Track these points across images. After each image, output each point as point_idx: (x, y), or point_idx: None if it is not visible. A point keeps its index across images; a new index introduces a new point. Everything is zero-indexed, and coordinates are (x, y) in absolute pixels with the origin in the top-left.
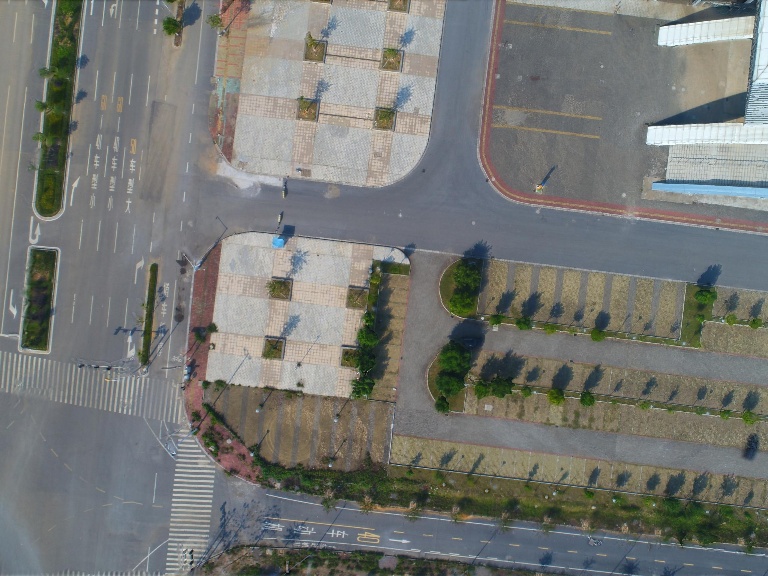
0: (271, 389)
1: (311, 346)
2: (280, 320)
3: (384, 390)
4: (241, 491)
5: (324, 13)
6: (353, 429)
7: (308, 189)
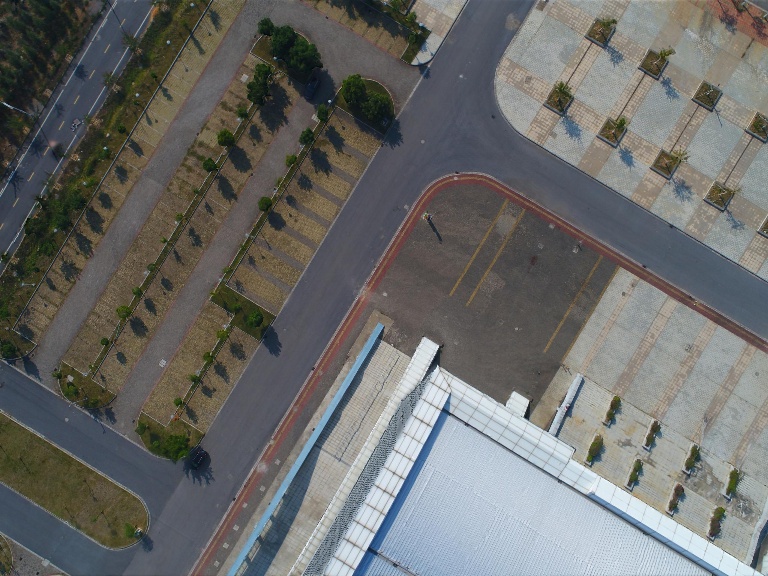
0: None
1: None
2: None
3: None
4: None
5: (686, 89)
6: None
7: (525, 1)
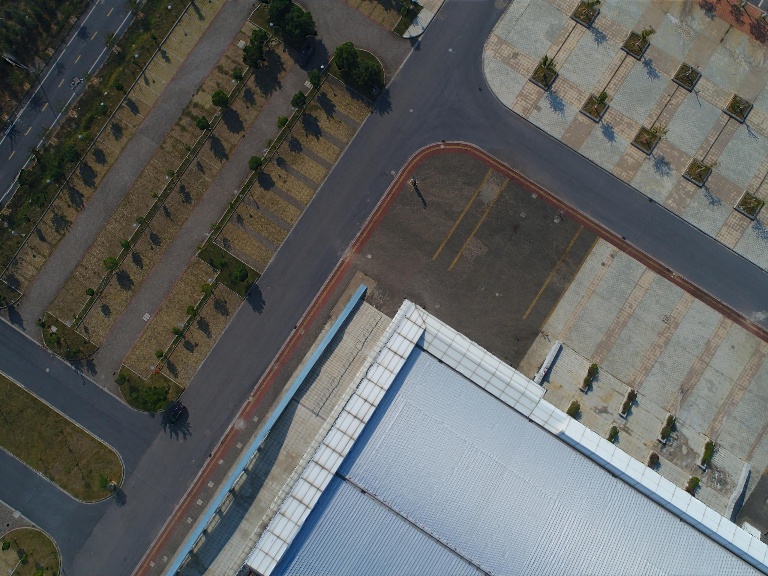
0: None
1: None
2: None
3: None
4: None
5: (667, 70)
6: None
7: None
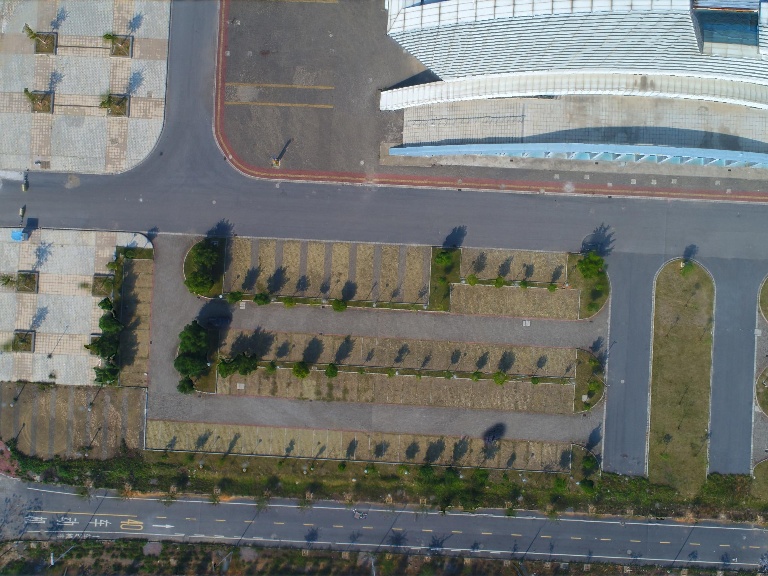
0: (23, 382)
1: (60, 337)
2: (29, 313)
3: (135, 376)
4: (2, 486)
5: (52, 5)
6: (107, 417)
7: (49, 181)
